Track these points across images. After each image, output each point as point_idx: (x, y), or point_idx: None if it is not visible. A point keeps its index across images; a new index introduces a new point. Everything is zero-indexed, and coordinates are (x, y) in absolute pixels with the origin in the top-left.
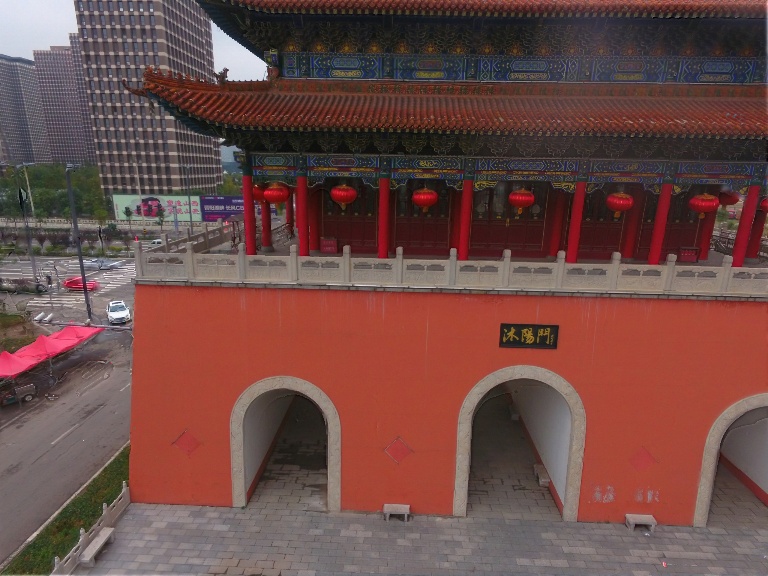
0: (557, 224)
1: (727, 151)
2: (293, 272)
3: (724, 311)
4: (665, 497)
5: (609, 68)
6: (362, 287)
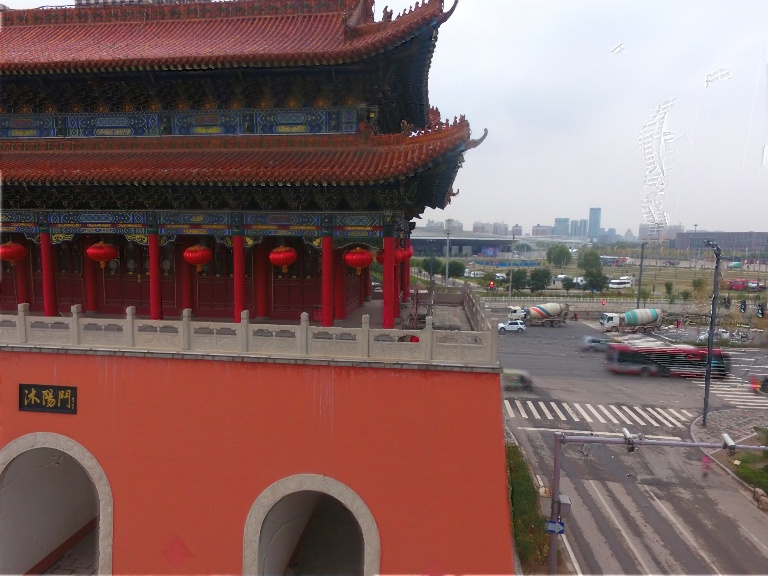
0: (184, 280)
1: None
2: None
3: (246, 374)
4: None
5: (187, 122)
6: None
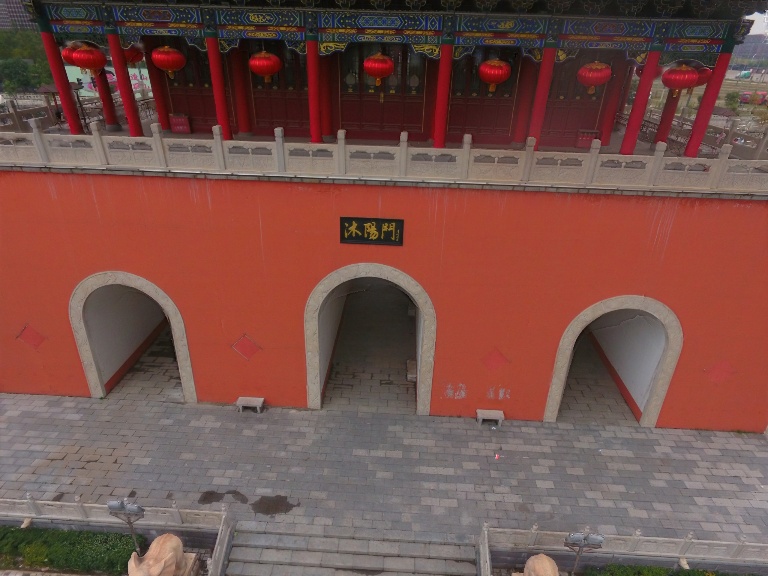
0: None
1: (624, 3)
2: (100, 155)
3: (587, 205)
4: (517, 394)
5: None
6: (180, 173)
